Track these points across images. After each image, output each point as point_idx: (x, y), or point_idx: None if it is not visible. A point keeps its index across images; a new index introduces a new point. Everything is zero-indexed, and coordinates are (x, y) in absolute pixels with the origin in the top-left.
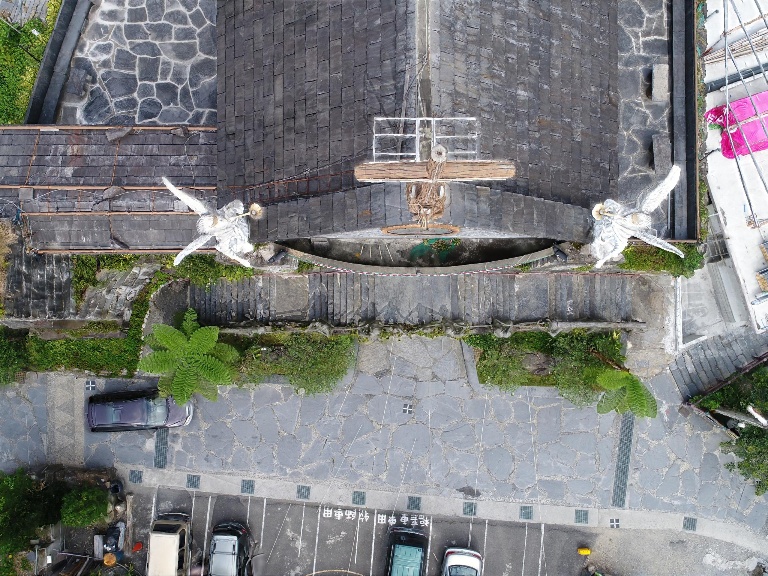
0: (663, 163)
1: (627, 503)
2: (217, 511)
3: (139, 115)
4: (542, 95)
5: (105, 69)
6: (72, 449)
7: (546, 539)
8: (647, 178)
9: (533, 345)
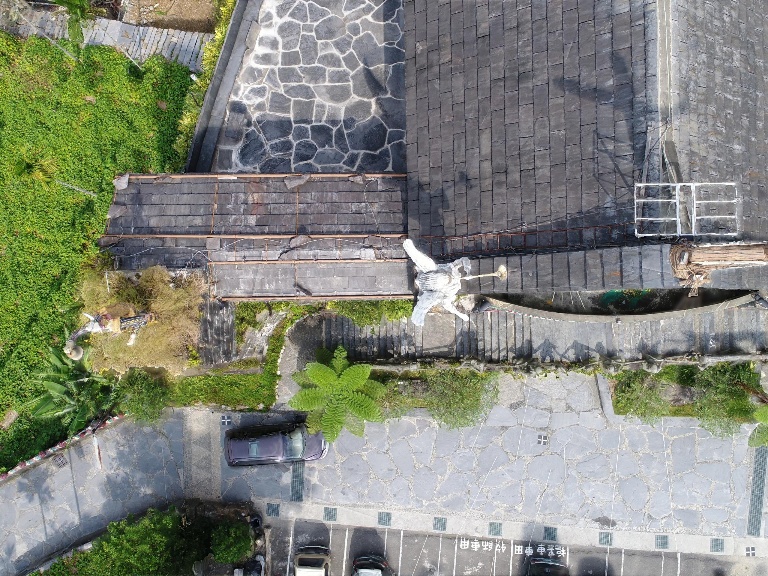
0: None
1: (762, 531)
2: (354, 543)
3: (294, 157)
4: (751, 147)
5: (260, 112)
6: (209, 483)
7: (683, 568)
8: None
9: (669, 376)
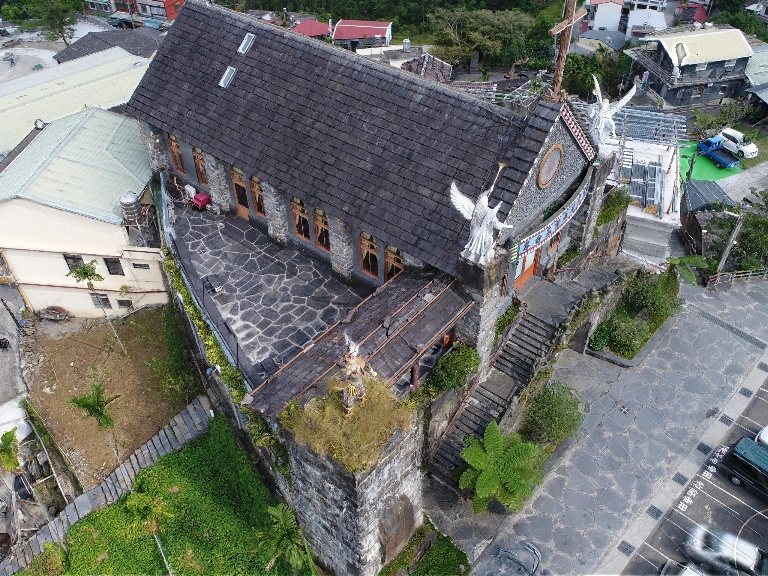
0: None
1: (765, 342)
2: None
3: None
4: None
5: (275, 358)
6: None
7: None
8: None
9: None
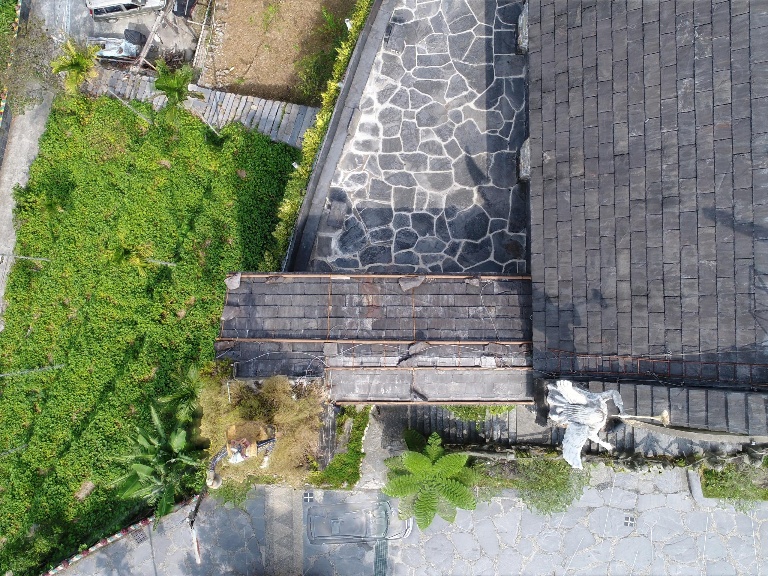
0: None
1: None
2: None
3: (395, 245)
4: None
5: (360, 199)
6: (291, 561)
7: None
8: None
9: None
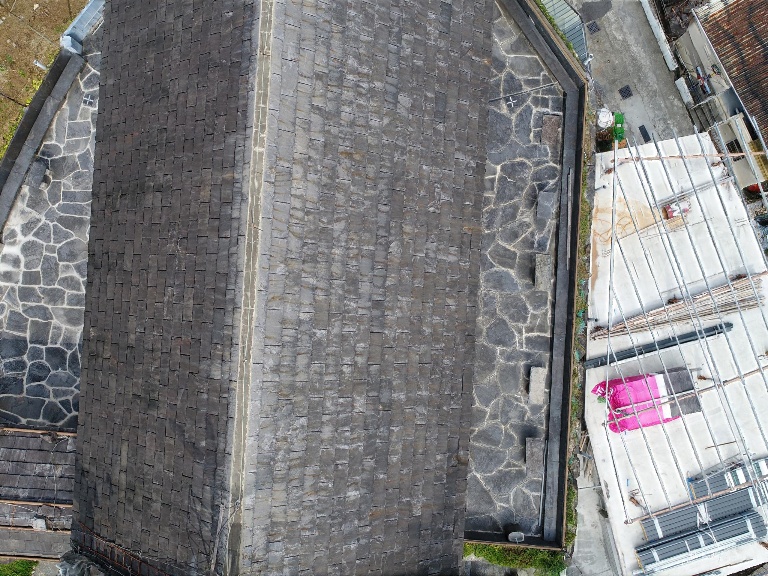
0: (535, 467)
1: None
2: None
3: (27, 377)
4: (377, 486)
5: None
6: None
7: None
8: (522, 473)
9: None
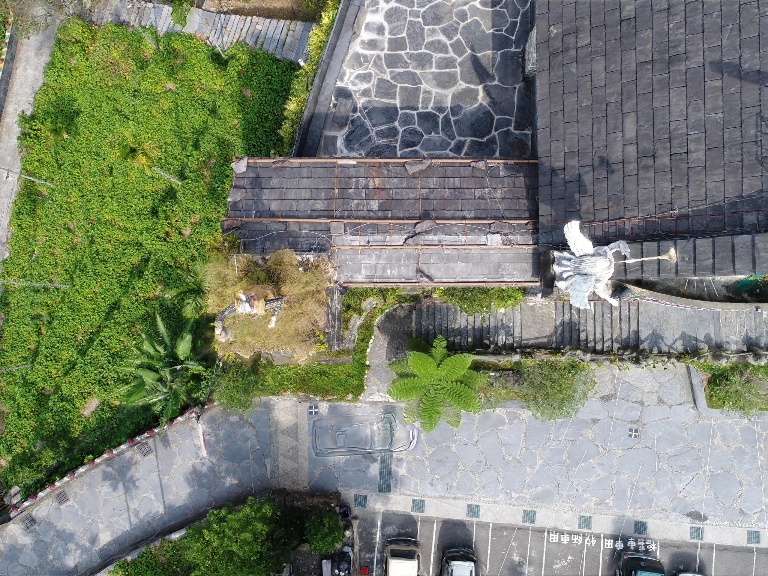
0: None
1: None
2: (443, 535)
3: (400, 144)
4: None
5: (365, 98)
6: (296, 473)
7: None
8: None
9: (764, 370)
